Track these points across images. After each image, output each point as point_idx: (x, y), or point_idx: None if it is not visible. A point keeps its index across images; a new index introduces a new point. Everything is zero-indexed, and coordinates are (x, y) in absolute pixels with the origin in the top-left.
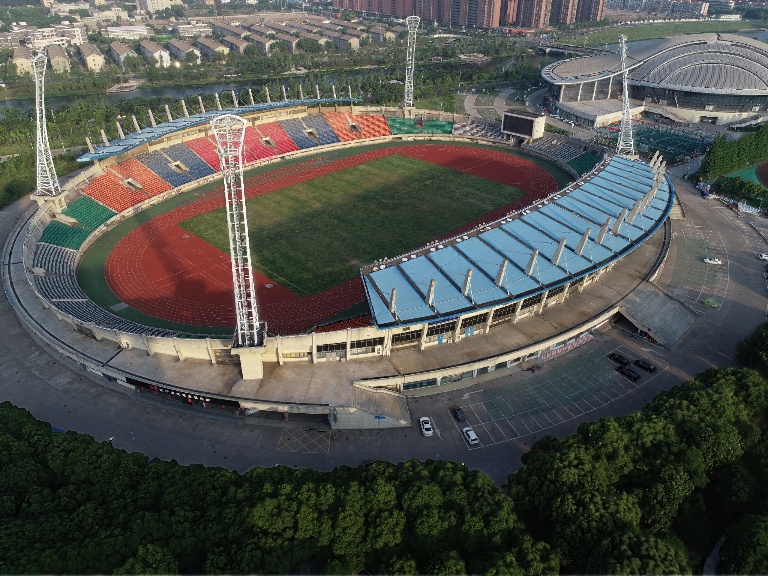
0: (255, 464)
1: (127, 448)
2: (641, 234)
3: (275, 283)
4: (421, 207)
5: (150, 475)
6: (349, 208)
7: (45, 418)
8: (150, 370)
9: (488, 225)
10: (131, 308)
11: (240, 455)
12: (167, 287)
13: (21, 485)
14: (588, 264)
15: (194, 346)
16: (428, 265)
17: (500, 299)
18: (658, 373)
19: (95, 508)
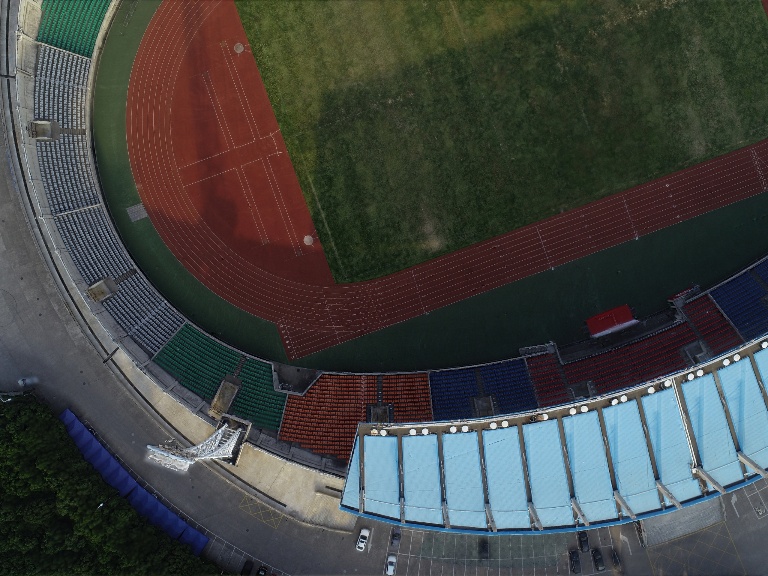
0: (219, 515)
1: (128, 452)
2: (733, 481)
3: (317, 238)
4: (600, 101)
5: (123, 567)
6: (493, 54)
7: (65, 383)
8: (148, 386)
9: (548, 411)
10: (149, 222)
11: (210, 500)
12: (193, 189)
13: (40, 523)
14: (612, 515)
15: (184, 400)
16: (433, 452)
17: (475, 527)
18: (603, 571)
19: (88, 567)
